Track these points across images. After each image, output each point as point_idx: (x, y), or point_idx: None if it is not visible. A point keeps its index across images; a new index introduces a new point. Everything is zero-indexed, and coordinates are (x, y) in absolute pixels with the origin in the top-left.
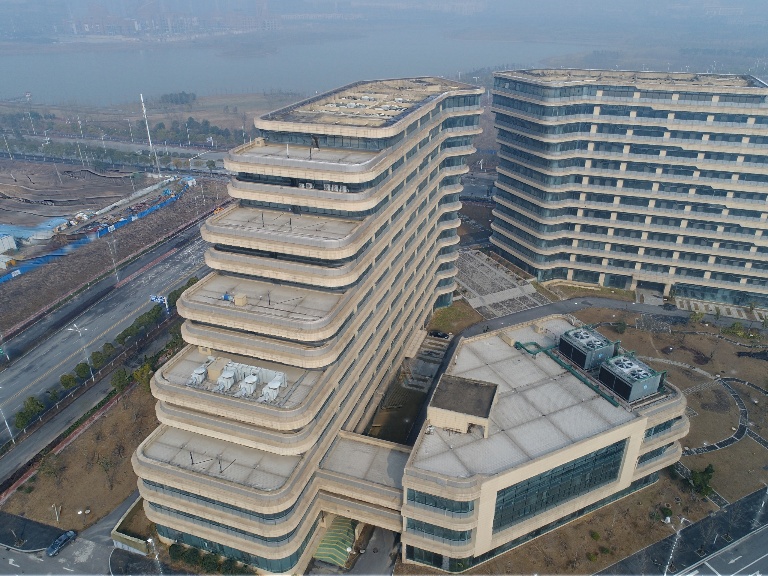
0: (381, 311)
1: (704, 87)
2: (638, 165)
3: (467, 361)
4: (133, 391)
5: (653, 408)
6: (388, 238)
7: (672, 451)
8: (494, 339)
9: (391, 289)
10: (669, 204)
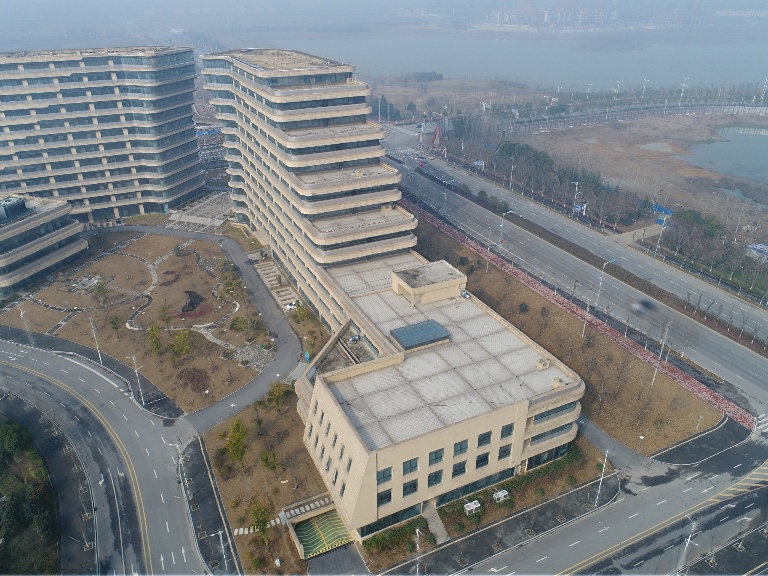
0: None
1: (246, 67)
2: None
3: None
4: None
5: None
6: None
7: None
8: None
9: (19, 160)
10: None
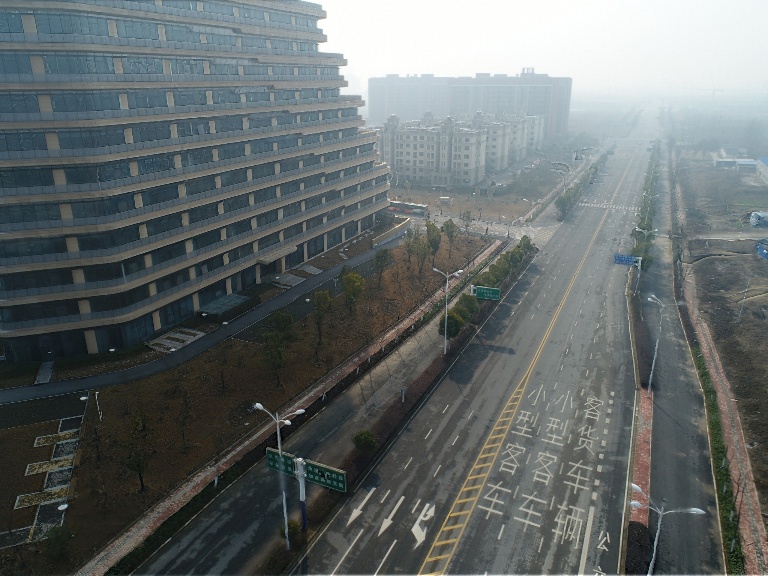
0: None
1: None
2: None
3: None
4: (454, 266)
5: None
6: None
7: None
8: None
9: None
10: None
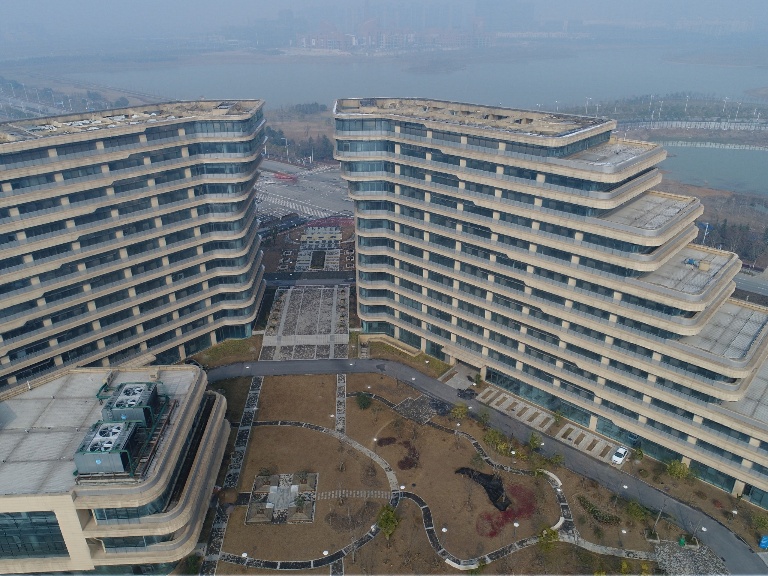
0: (7, 323)
1: (486, 131)
2: (440, 217)
3: (44, 390)
4: None
5: (92, 488)
6: (4, 253)
7: (165, 548)
8: (103, 375)
9: (46, 305)
10: (473, 269)
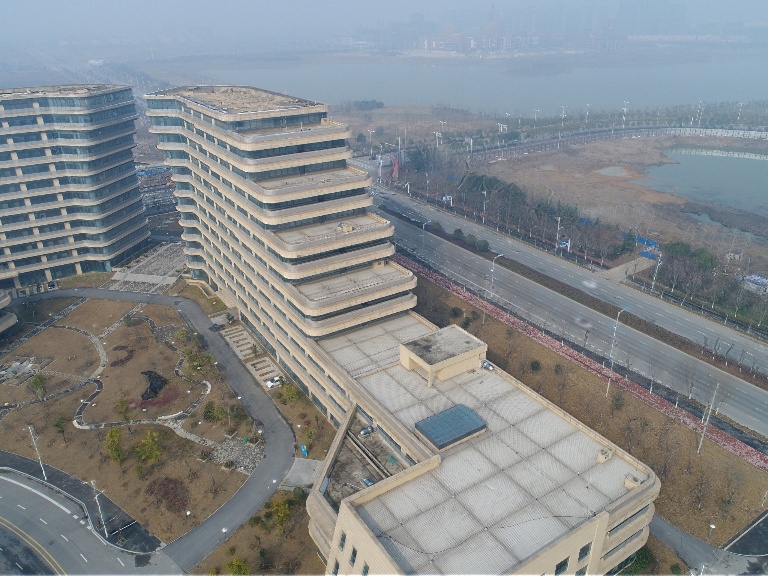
0: None
1: (204, 109)
2: None
3: None
4: None
5: None
6: None
7: None
8: None
9: None
10: None
